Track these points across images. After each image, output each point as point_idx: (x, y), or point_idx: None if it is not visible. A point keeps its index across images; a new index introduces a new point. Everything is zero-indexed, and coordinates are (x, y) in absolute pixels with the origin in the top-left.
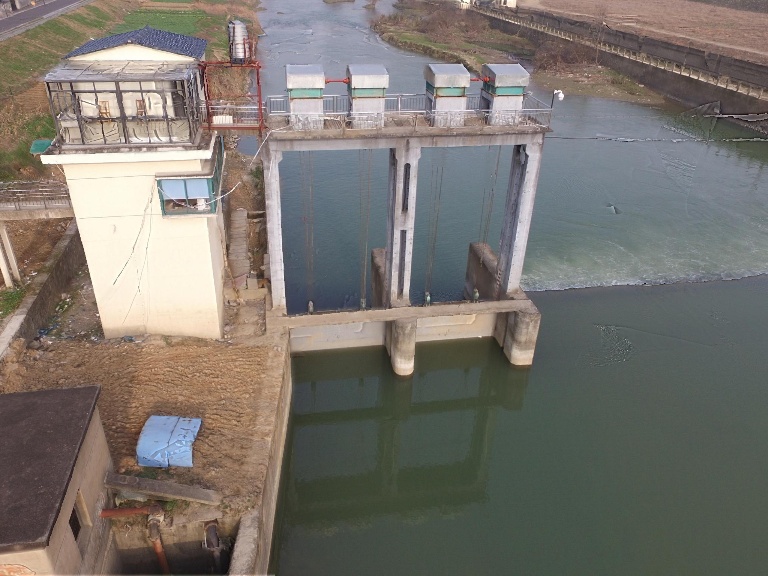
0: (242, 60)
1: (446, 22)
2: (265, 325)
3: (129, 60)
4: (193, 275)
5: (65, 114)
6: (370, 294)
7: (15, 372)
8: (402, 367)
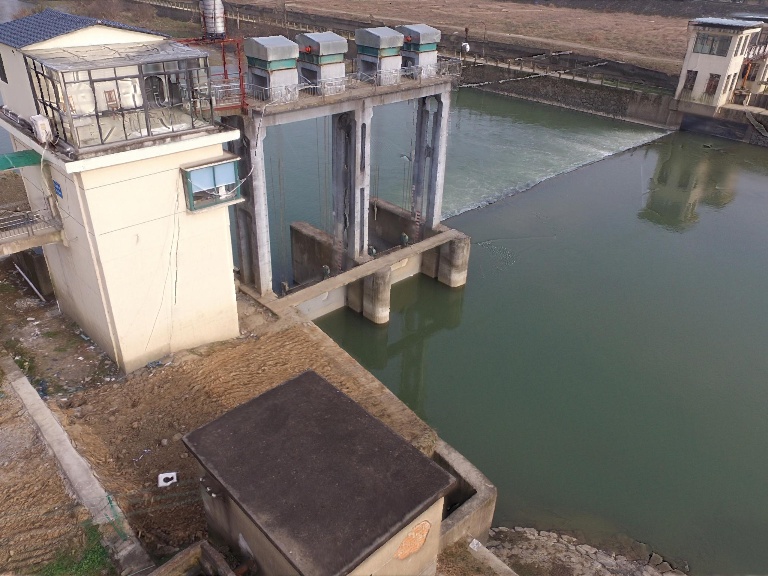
0: (223, 35)
1: (110, 12)
2: (271, 311)
3: (93, 45)
4: (215, 273)
5: None
6: (295, 269)
7: (84, 433)
8: (383, 315)
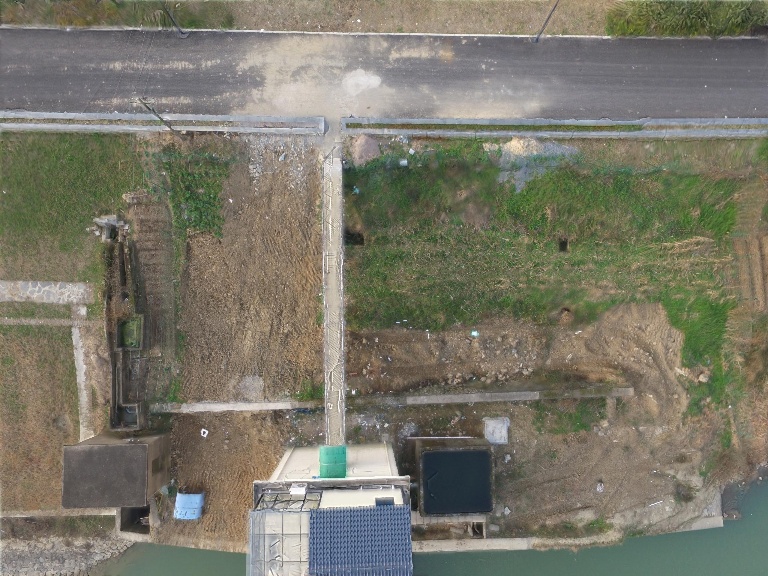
0: None
1: None
2: None
3: None
4: None
5: (276, 503)
6: None
7: (245, 416)
8: None
